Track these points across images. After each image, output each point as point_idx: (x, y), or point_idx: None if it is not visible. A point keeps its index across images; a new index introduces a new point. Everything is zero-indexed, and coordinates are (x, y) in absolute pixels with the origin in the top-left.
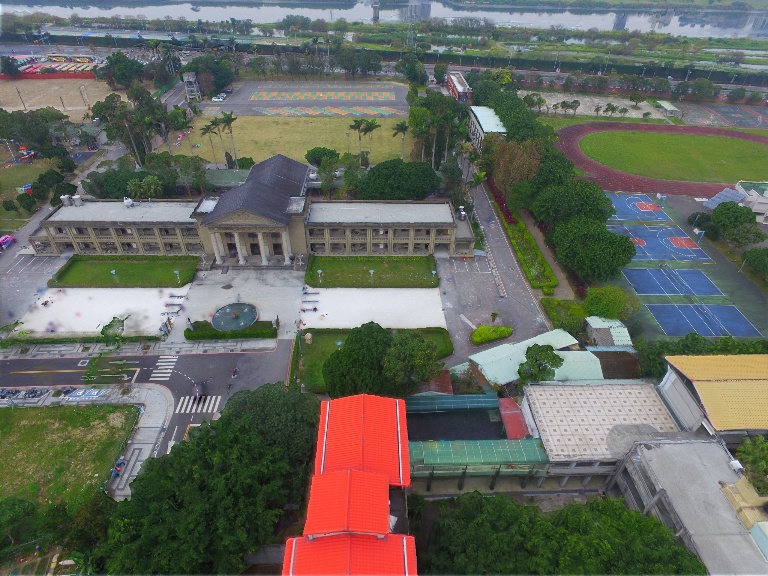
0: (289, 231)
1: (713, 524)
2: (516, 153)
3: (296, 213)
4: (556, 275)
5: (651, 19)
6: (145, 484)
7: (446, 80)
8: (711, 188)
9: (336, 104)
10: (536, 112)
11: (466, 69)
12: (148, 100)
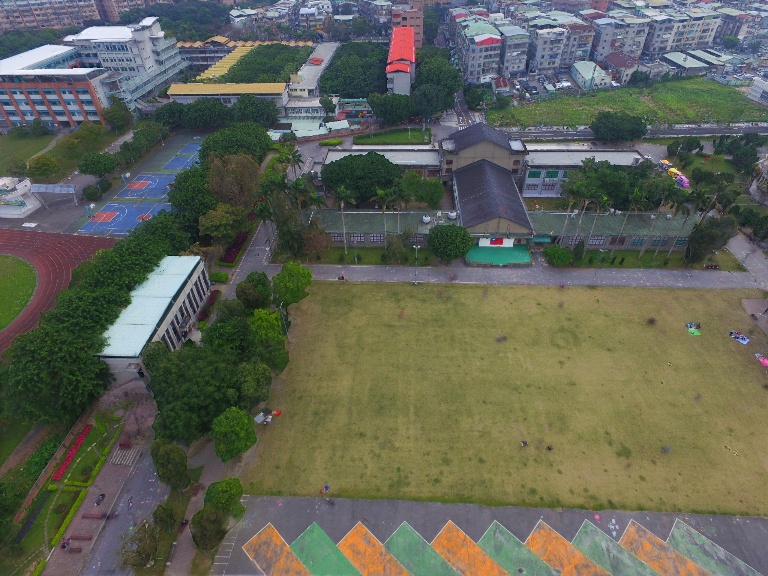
0: None
1: (310, 80)
2: None
3: None
4: None
5: None
6: (456, 75)
7: None
8: None
9: None
10: None
11: None
12: None
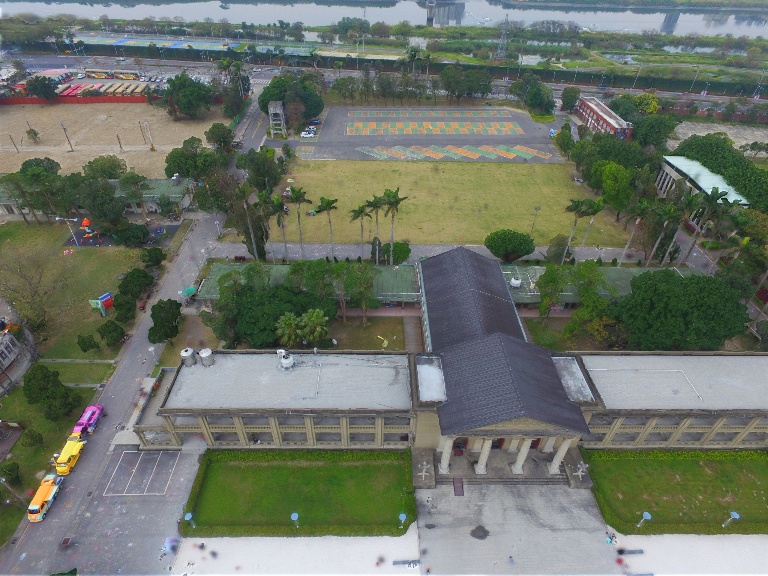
0: None
1: None
2: None
3: (588, 402)
4: None
5: None
6: None
7: (577, 107)
8: None
9: (457, 141)
10: None
11: (586, 89)
12: (253, 155)
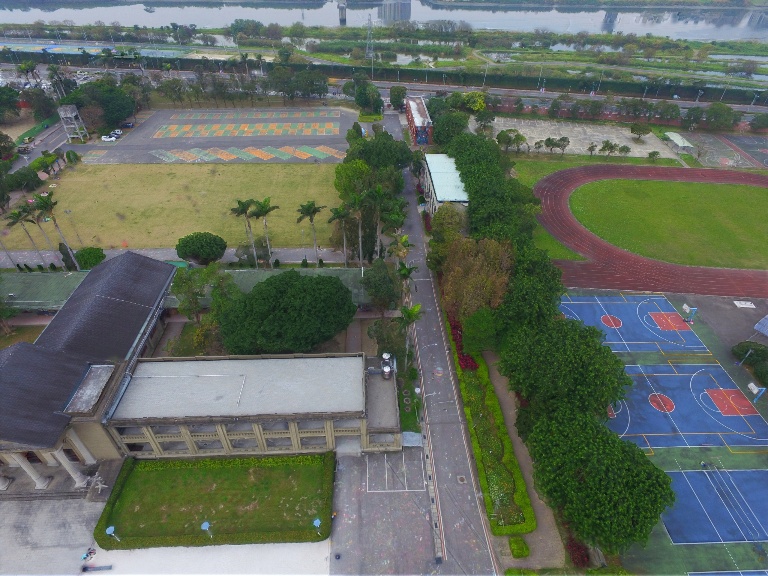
0: (78, 434)
1: None
2: (472, 264)
3: (80, 412)
4: (534, 497)
5: (651, 24)
6: None
7: (405, 106)
8: (754, 280)
9: (261, 143)
10: (514, 151)
11: (432, 88)
12: None
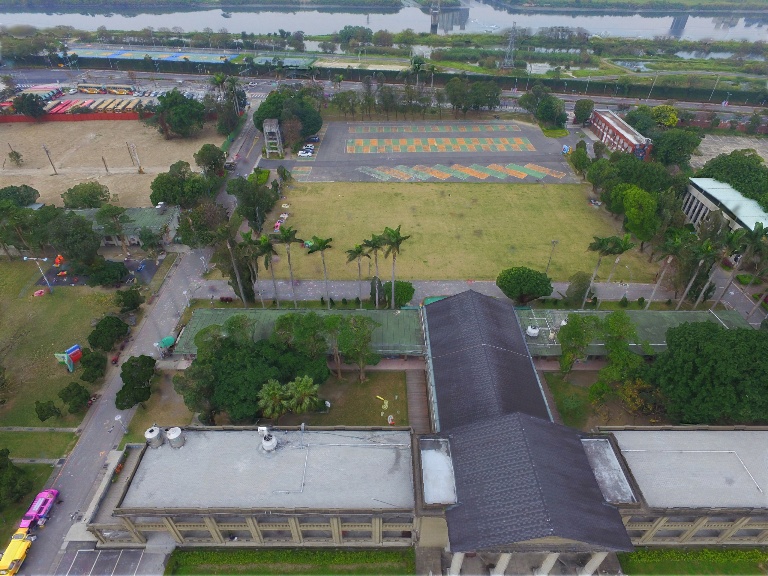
0: None
1: None
2: None
3: (628, 504)
4: None
5: None
6: None
7: (591, 120)
8: None
9: (463, 160)
10: None
11: (599, 100)
12: (242, 184)
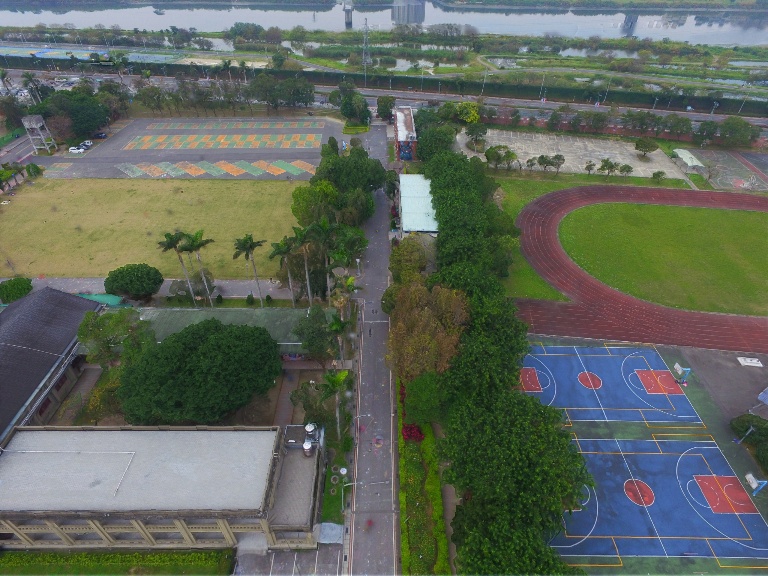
0: None
1: None
2: (416, 319)
3: None
4: None
5: (665, 29)
6: None
7: (393, 117)
8: (763, 330)
9: (234, 156)
10: (504, 169)
11: (426, 97)
12: None
